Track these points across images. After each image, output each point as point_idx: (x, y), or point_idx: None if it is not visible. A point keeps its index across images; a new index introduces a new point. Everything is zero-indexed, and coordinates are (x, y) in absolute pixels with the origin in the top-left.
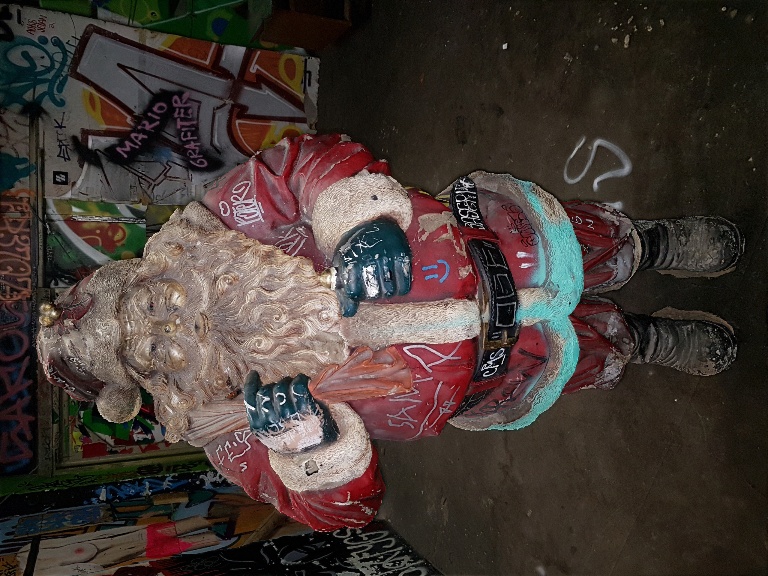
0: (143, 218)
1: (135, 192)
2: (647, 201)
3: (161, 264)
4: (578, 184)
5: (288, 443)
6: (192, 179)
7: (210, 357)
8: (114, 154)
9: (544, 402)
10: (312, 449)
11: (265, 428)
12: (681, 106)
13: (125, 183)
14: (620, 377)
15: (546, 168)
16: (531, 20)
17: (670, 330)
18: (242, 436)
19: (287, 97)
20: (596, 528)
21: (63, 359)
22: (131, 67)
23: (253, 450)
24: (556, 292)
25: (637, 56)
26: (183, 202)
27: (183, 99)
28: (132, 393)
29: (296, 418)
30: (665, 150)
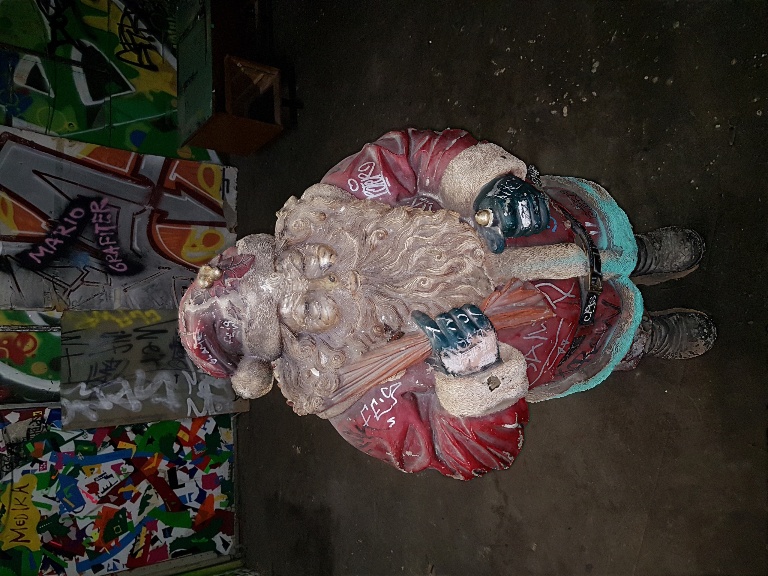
0: (57, 325)
1: (49, 298)
2: None
3: (307, 230)
4: None
5: (472, 361)
6: (111, 283)
7: (364, 309)
8: (26, 260)
9: (621, 351)
10: (488, 368)
11: (454, 345)
12: (623, 152)
13: (38, 289)
14: None
15: None
16: (470, 107)
17: (660, 322)
18: (388, 391)
19: (206, 203)
20: (609, 537)
21: (214, 325)
22: (47, 174)
23: (399, 404)
24: (621, 252)
25: (576, 121)
26: (102, 307)
27: (101, 205)
28: (269, 365)
29: (480, 334)
30: (615, 188)
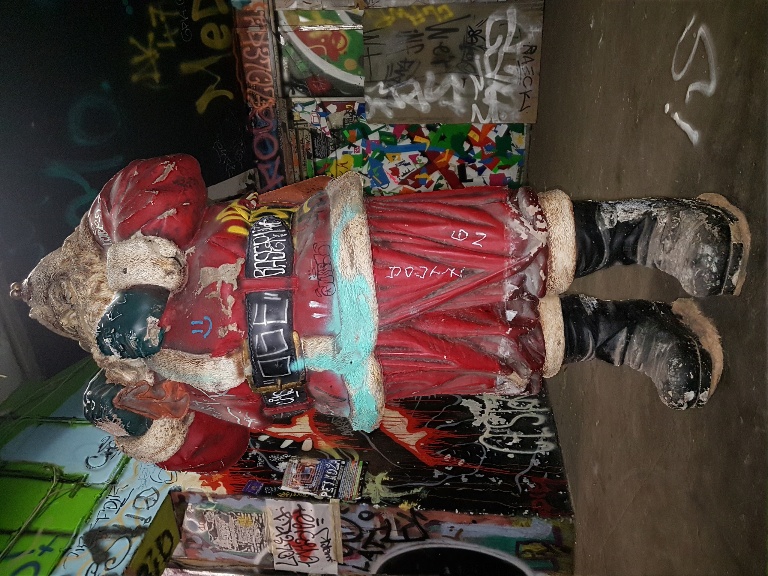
0: (361, 24)
1: None
2: (714, 146)
3: (63, 268)
4: (678, 84)
5: None
6: None
7: None
8: None
9: (360, 427)
10: (127, 437)
11: None
12: (767, 15)
13: None
14: (537, 389)
15: (664, 44)
16: None
17: (644, 342)
18: None
19: None
20: (622, 472)
21: None
22: None
23: None
24: (340, 349)
25: None
26: (398, 3)
27: None
28: None
29: (101, 421)
30: (742, 79)
